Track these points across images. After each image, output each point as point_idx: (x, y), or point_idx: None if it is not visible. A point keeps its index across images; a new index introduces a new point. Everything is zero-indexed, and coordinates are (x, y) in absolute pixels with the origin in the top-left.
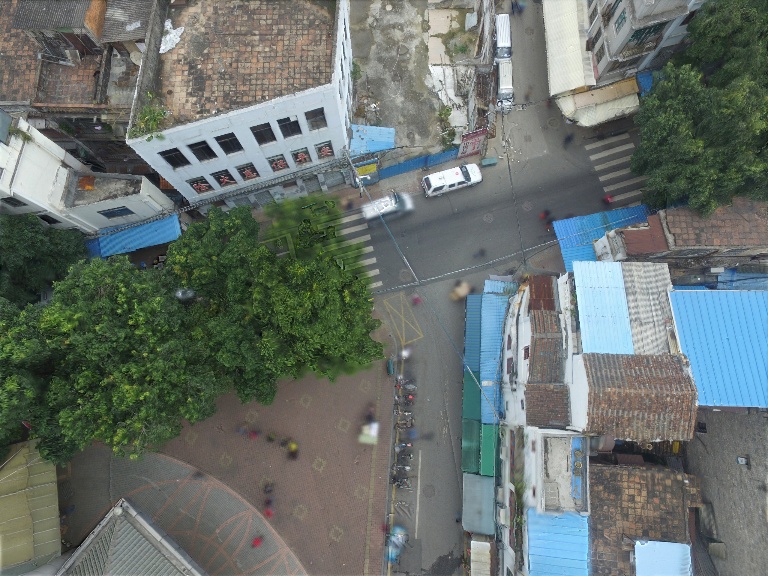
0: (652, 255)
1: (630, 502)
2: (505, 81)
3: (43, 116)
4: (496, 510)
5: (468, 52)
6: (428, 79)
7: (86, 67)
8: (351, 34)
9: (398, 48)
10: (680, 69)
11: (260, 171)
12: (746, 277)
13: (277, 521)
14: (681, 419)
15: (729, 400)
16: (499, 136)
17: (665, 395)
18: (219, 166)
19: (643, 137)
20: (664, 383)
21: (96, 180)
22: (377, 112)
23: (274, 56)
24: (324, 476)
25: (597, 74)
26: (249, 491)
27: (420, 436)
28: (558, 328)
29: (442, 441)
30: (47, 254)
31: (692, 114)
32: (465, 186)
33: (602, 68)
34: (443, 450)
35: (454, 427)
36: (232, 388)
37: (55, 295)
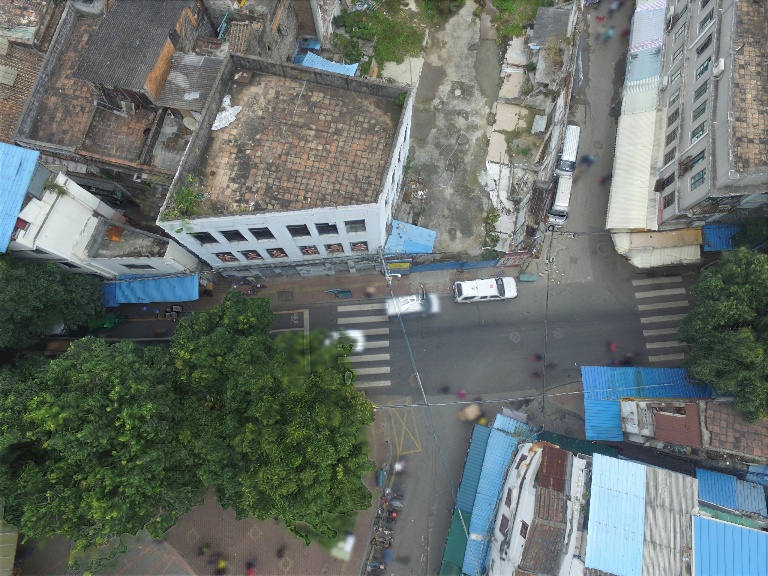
0: None
1: None
2: (562, 198)
3: (86, 163)
4: None
5: (529, 156)
6: (482, 175)
7: (138, 120)
8: (414, 113)
9: (458, 137)
10: (753, 256)
11: (289, 254)
12: None
13: None
14: None
15: None
16: (544, 251)
17: None
18: (248, 247)
19: (698, 316)
20: None
21: (124, 232)
22: (423, 200)
23: (326, 156)
24: None
25: (661, 219)
26: (209, 575)
27: (396, 558)
28: (563, 517)
29: (417, 569)
30: (59, 301)
31: (757, 304)
32: (497, 299)
33: (667, 216)
34: None
35: (433, 557)
36: (210, 487)
37: (50, 372)
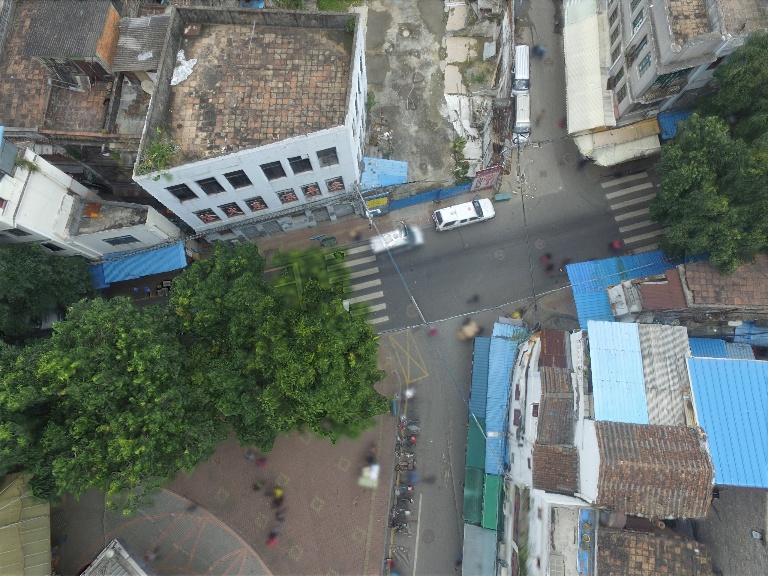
0: (669, 309)
1: (637, 569)
2: (522, 115)
3: (51, 142)
4: (497, 567)
5: (485, 82)
6: (443, 108)
7: (96, 93)
8: (367, 59)
9: (414, 75)
10: (706, 120)
11: (269, 203)
12: (764, 331)
13: (272, 561)
14: (696, 497)
15: (747, 479)
16: (514, 170)
17: (680, 471)
18: (227, 199)
19: (664, 188)
20: (679, 458)
21: (102, 208)
22: (390, 141)
23: (287, 92)
24: (322, 516)
25: (618, 114)
26: (245, 528)
27: (421, 479)
28: (569, 388)
29: (444, 485)
30: (49, 283)
31: (716, 166)
32: (477, 221)
33: (623, 109)
34: (444, 495)
35: (456, 471)
36: (231, 430)
37: (54, 336)
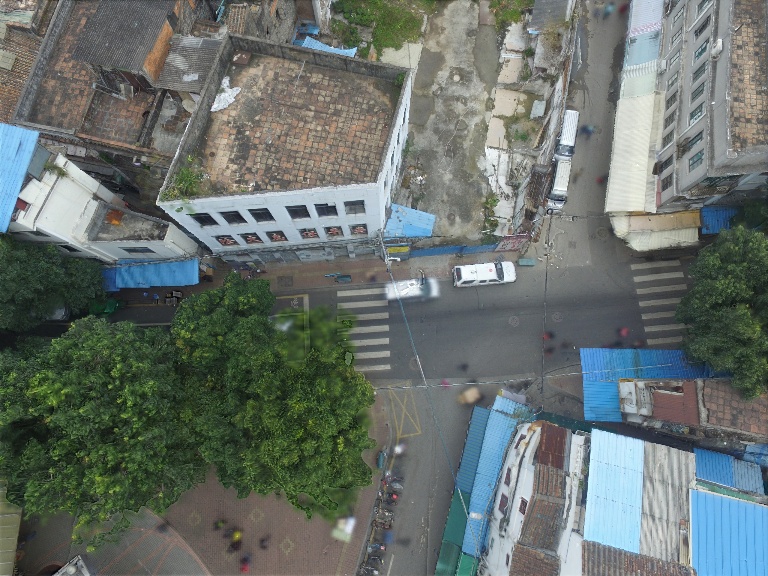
0: None
1: None
2: (560, 182)
3: (85, 146)
4: None
5: (528, 141)
6: (481, 161)
7: (137, 103)
8: (412, 98)
9: (457, 122)
10: (751, 235)
11: (289, 237)
12: None
13: None
14: None
15: None
16: (543, 236)
17: None
18: (248, 229)
19: (696, 295)
20: None
21: (124, 216)
22: (422, 185)
23: (325, 137)
24: (289, 559)
25: (659, 202)
26: (211, 557)
27: (396, 539)
28: (562, 492)
29: (418, 550)
30: (60, 284)
31: (754, 283)
32: (496, 283)
33: (666, 198)
34: (417, 560)
35: (433, 538)
36: (212, 467)
37: (52, 351)
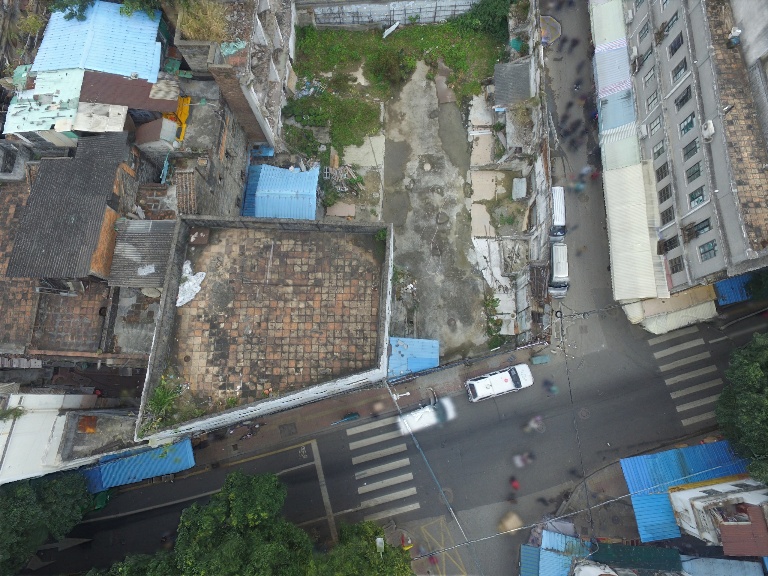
0: None
1: None
2: (560, 269)
3: (39, 359)
4: None
5: (516, 224)
6: (471, 254)
7: (91, 297)
8: (385, 198)
9: (437, 216)
10: None
11: None
12: None
13: None
14: None
15: None
16: None
17: None
18: None
19: (742, 410)
20: None
21: (99, 420)
22: (414, 293)
23: (310, 314)
24: None
25: (671, 285)
26: None
27: None
28: None
29: None
30: (39, 521)
31: None
32: (514, 390)
33: (678, 282)
34: None
35: None
36: None
37: None
